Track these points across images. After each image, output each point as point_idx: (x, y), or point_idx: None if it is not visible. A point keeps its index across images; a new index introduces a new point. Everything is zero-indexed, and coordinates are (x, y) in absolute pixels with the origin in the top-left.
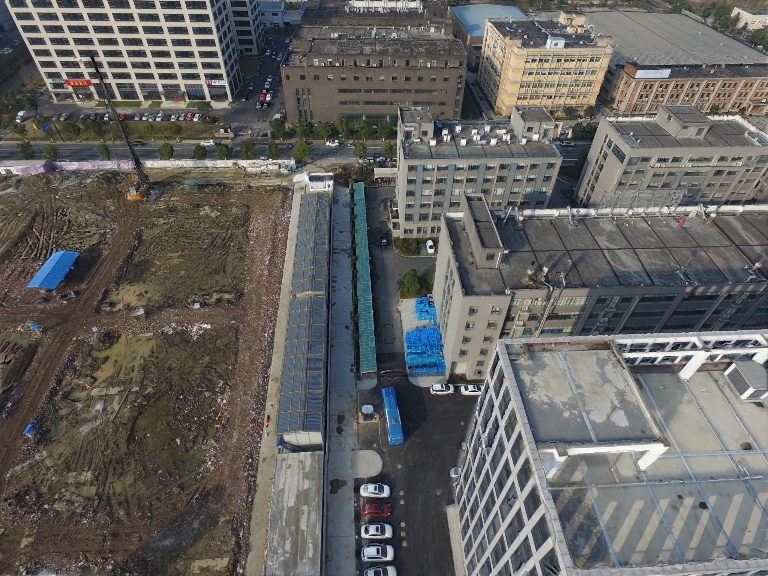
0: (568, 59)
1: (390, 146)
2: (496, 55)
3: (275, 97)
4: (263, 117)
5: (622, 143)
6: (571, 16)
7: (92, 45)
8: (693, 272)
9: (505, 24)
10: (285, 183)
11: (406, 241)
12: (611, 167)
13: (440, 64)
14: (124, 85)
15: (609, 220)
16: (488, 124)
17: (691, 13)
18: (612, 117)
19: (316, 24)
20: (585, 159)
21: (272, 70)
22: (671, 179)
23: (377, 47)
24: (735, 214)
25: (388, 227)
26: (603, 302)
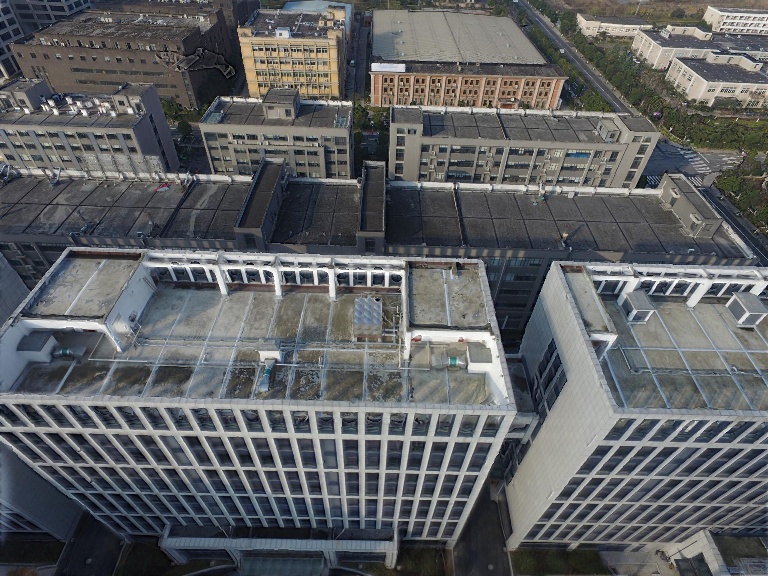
0: (295, 49)
1: None
2: None
3: None
4: None
5: None
6: (332, 10)
7: None
8: (104, 227)
9: (270, 16)
10: None
11: None
12: None
13: (159, 48)
14: None
15: None
16: None
17: (548, 18)
18: (227, 97)
19: (99, 10)
20: None
21: None
22: (256, 156)
23: (109, 30)
24: (227, 184)
25: None
26: (8, 248)
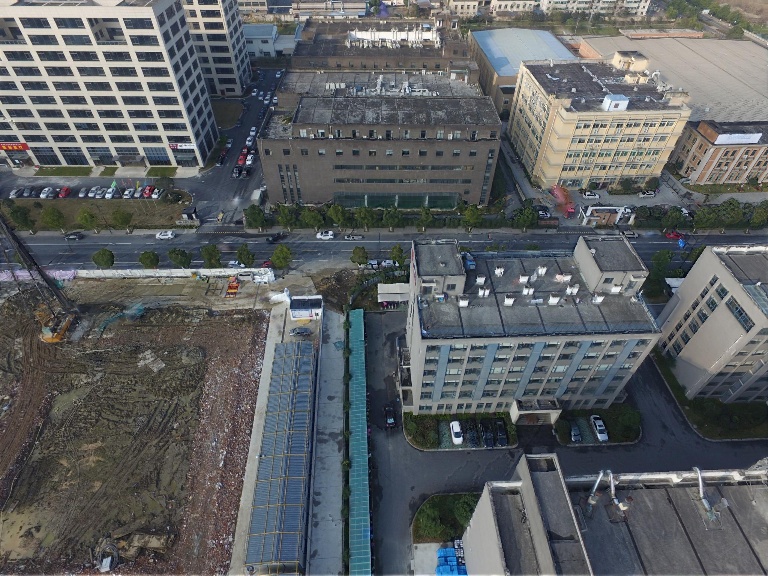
0: (631, 124)
1: (399, 251)
2: (535, 112)
3: (257, 159)
4: (240, 191)
5: (748, 303)
6: (629, 59)
7: (24, 104)
8: None
9: (545, 69)
10: (259, 306)
11: (421, 421)
12: (723, 327)
13: (465, 135)
14: (69, 149)
15: (764, 491)
16: (544, 265)
17: (751, 33)
18: (721, 247)
19: (308, 68)
20: (661, 272)
21: (257, 118)
22: None
23: (383, 110)
24: None
25: (396, 389)
26: None
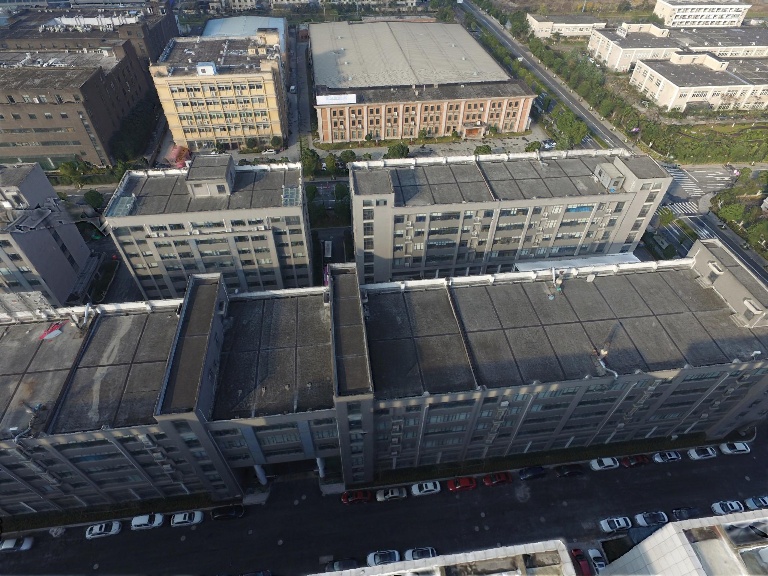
0: (223, 87)
1: None
2: None
3: None
4: None
5: None
6: (262, 34)
7: None
8: None
9: (189, 45)
10: None
11: None
12: None
13: (51, 99)
14: None
15: None
16: None
17: (496, 19)
18: (139, 171)
19: None
20: None
21: None
22: (185, 248)
23: None
24: (145, 312)
25: None
26: None
